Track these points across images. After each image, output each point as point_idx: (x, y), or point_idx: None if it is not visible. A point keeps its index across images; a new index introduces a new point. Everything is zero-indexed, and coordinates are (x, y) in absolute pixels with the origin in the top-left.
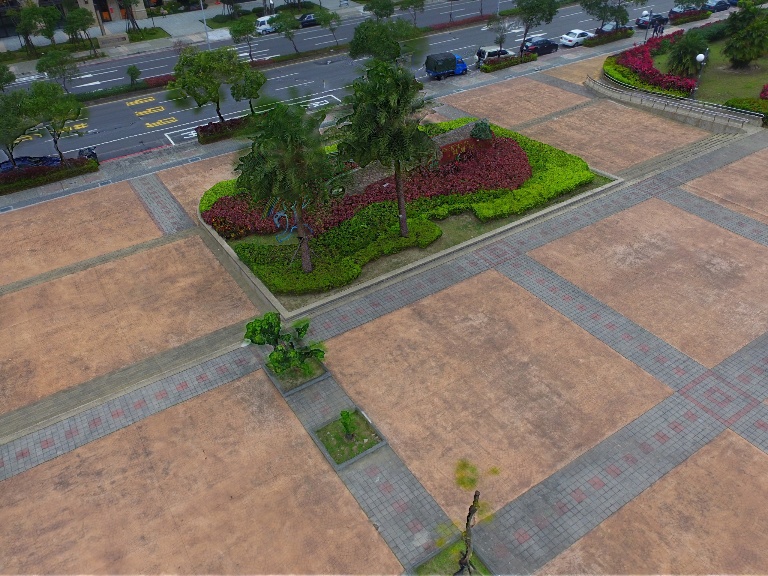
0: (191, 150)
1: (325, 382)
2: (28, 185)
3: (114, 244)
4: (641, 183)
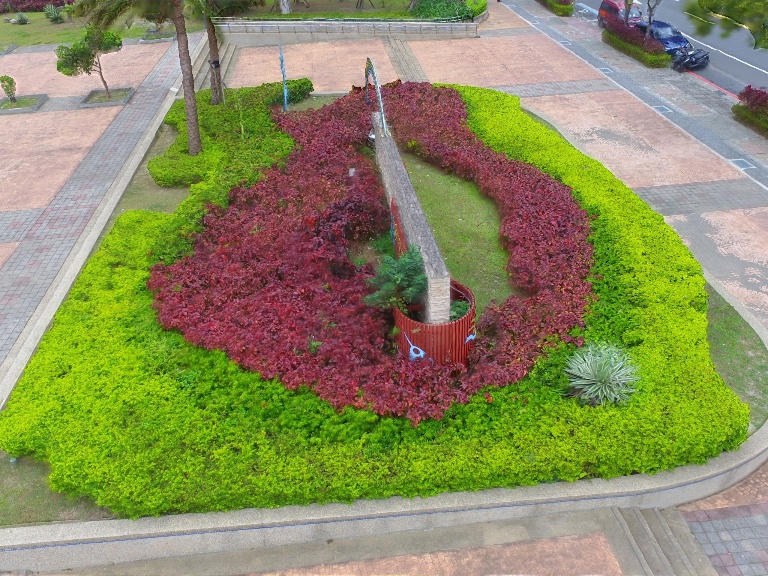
0: (708, 108)
1: (79, 106)
2: None
3: (441, 74)
4: None
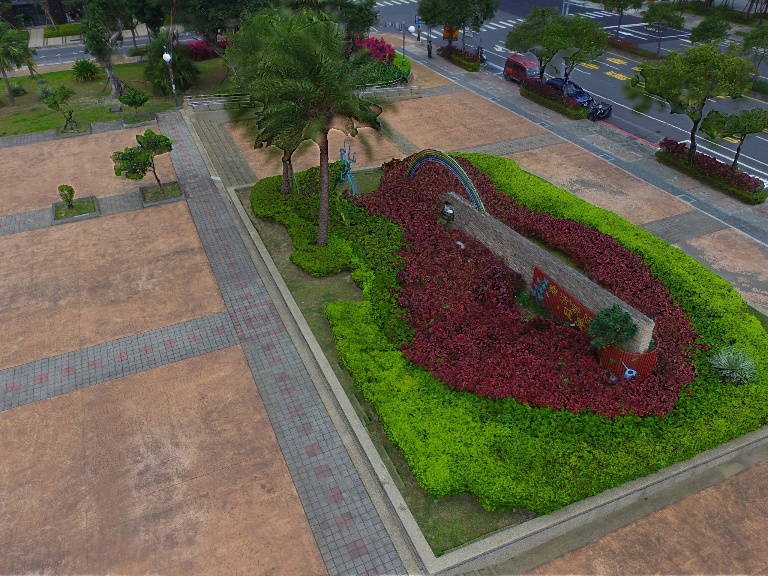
0: (636, 154)
1: (140, 205)
2: (534, 98)
3: (421, 138)
4: None
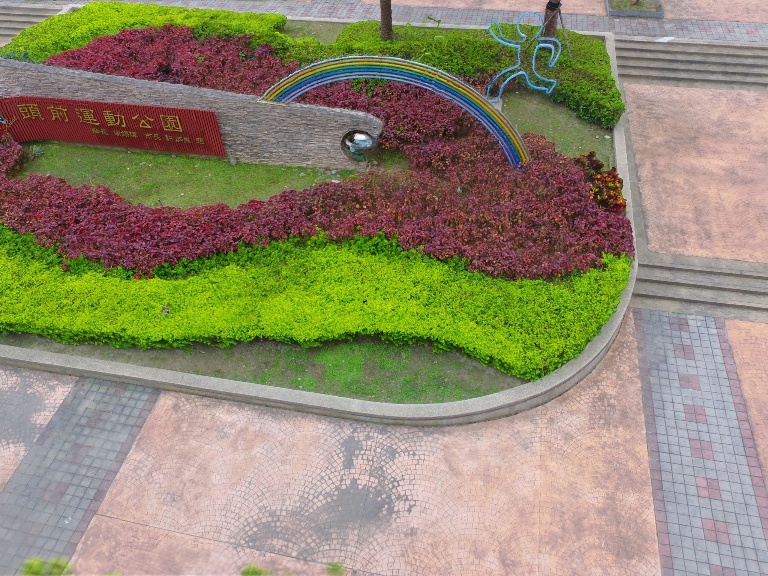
0: None
1: None
2: None
3: None
4: (64, 3)
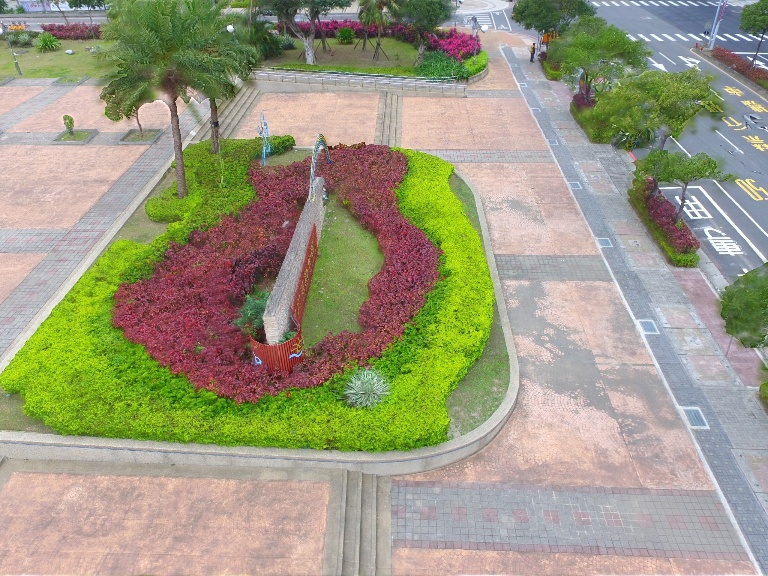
0: (613, 188)
1: None
2: None
3: (414, 133)
4: None
